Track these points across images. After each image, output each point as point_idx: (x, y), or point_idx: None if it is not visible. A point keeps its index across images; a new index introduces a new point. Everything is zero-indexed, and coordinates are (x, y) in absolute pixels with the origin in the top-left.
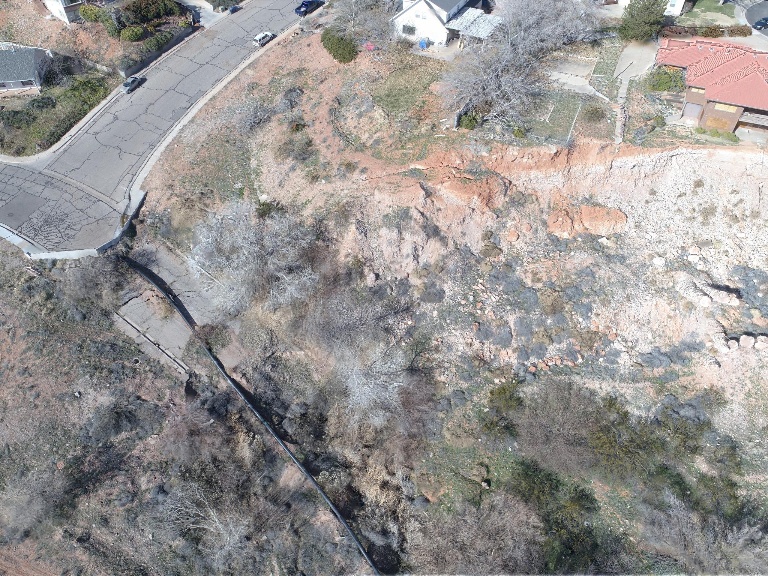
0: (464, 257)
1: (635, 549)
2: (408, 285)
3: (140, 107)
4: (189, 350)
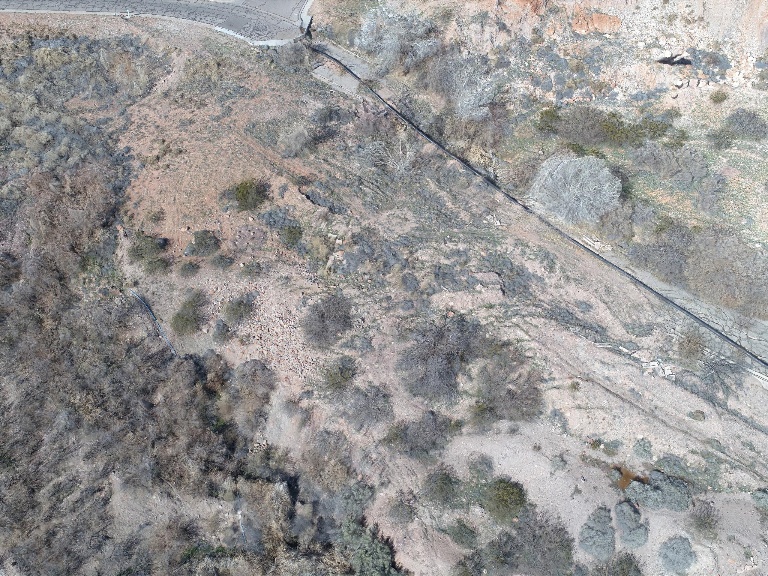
0: (521, 42)
1: (628, 169)
2: (487, 59)
3: None
4: (360, 90)
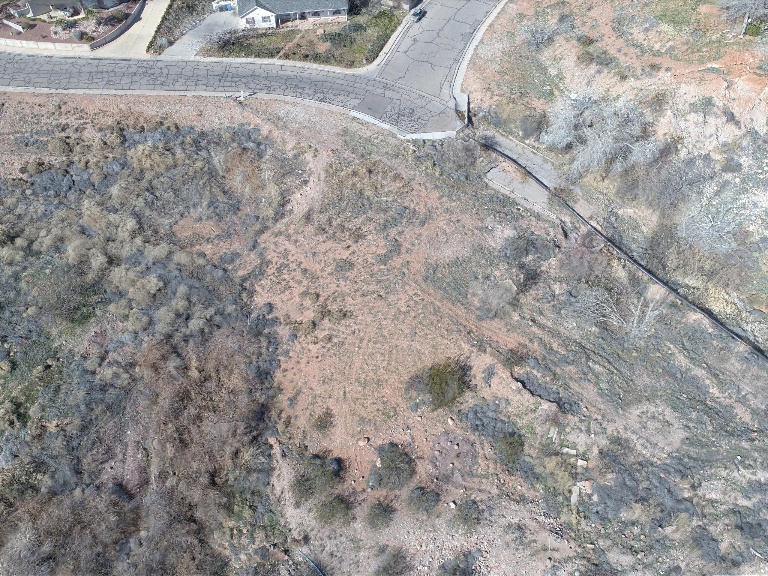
0: (755, 137)
1: None
2: (711, 159)
3: (432, 32)
4: (551, 204)
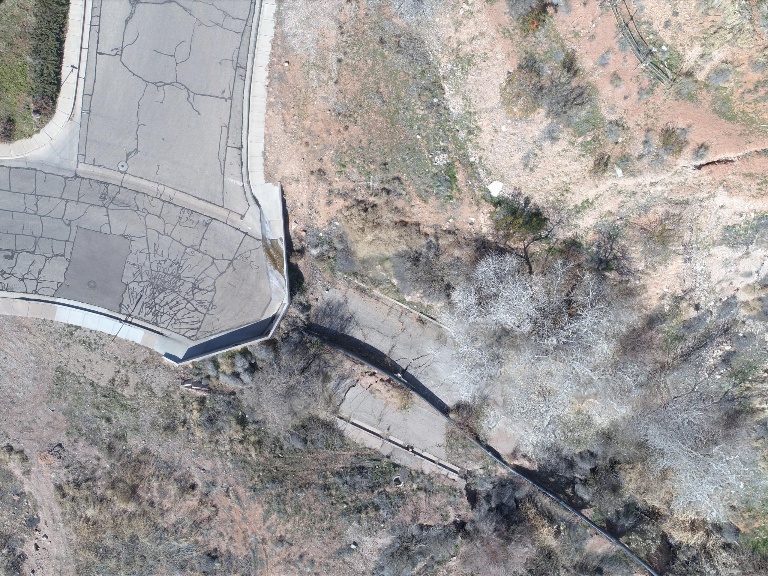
0: None
1: None
2: (734, 303)
3: None
4: (451, 444)
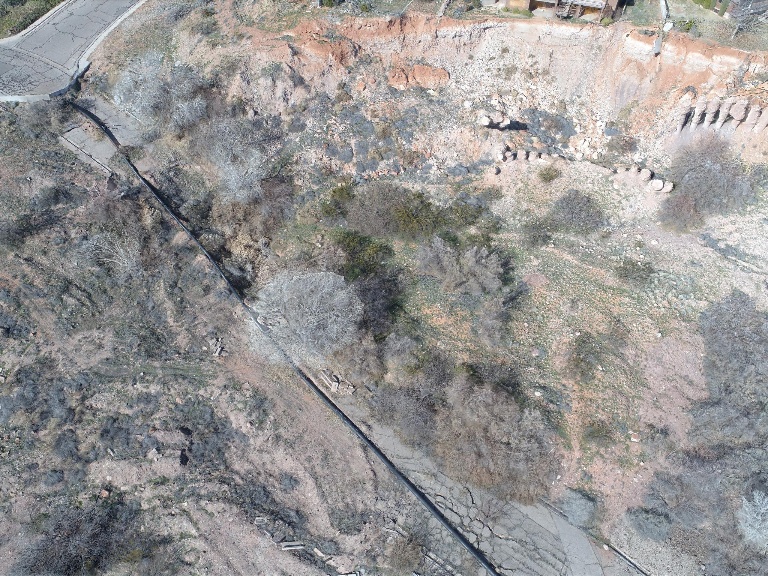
0: (322, 100)
1: (411, 273)
2: (280, 120)
3: (91, 6)
4: (113, 160)
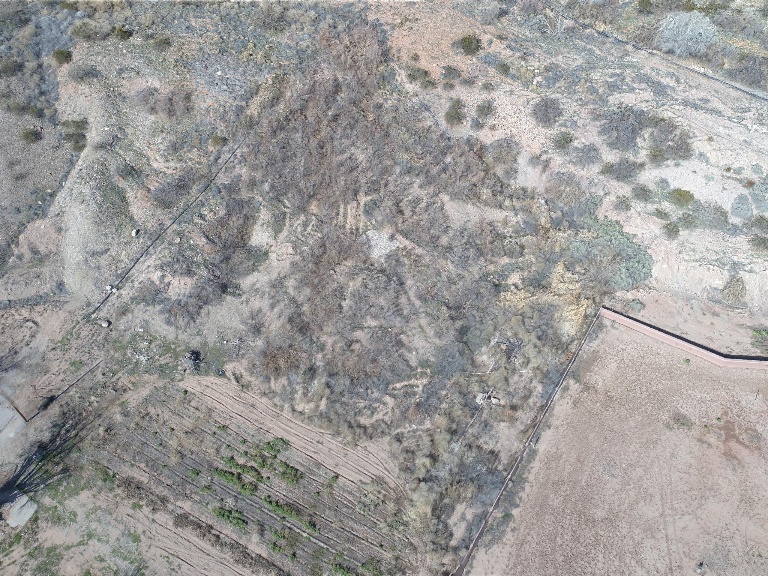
0: None
1: None
2: None
3: None
4: None
